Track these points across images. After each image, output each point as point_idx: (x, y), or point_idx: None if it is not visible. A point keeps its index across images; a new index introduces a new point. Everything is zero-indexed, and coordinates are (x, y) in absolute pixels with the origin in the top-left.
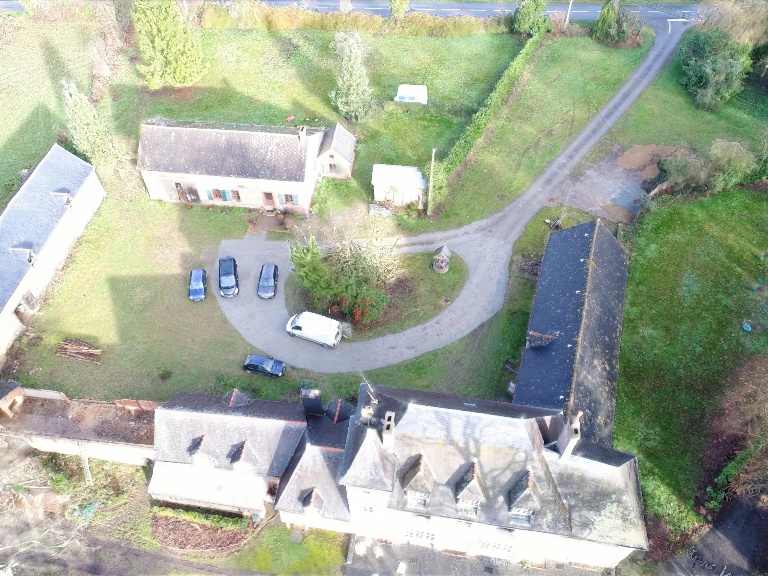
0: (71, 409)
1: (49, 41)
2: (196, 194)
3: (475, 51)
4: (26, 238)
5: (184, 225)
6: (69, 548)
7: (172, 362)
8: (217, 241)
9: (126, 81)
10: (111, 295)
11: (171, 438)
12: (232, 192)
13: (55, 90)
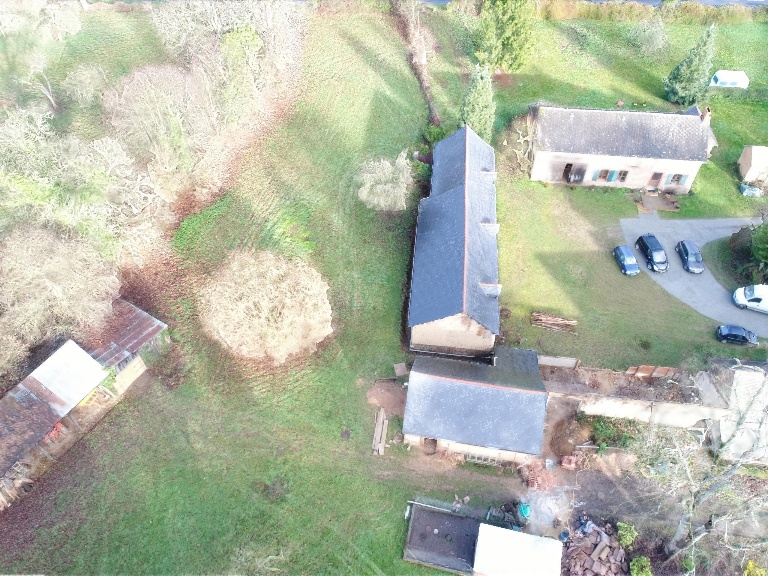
0: (582, 376)
1: (346, 31)
2: (582, 175)
3: (755, 39)
4: (484, 214)
5: (575, 205)
6: (663, 504)
7: (643, 333)
8: (615, 220)
9: (444, 69)
10: (547, 270)
11: (748, 399)
12: (619, 173)
13: (382, 78)
